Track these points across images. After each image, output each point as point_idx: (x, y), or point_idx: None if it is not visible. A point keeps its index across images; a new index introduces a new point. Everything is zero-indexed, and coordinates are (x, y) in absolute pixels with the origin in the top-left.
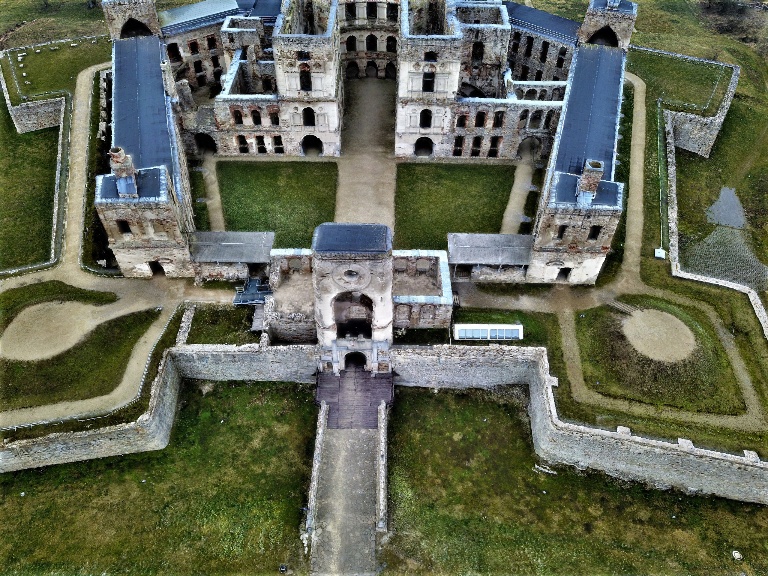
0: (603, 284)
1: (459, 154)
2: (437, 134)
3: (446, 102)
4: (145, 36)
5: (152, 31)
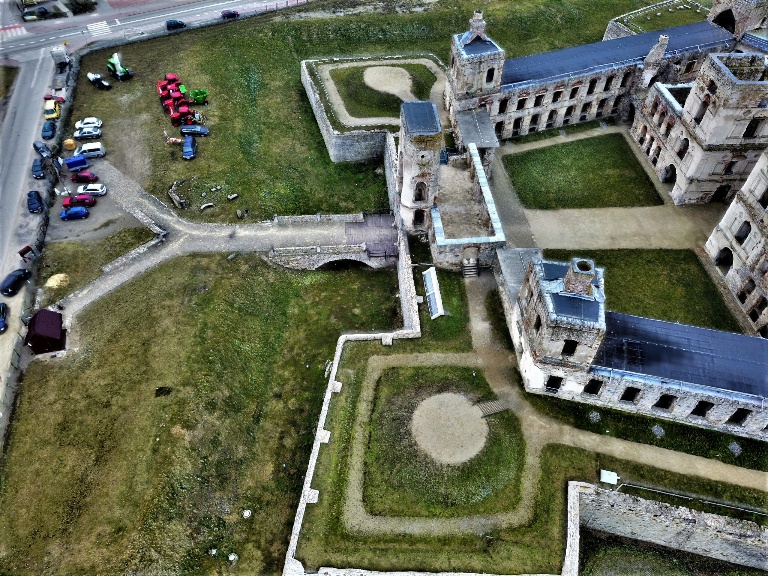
0: (530, 401)
1: (744, 302)
2: (740, 258)
3: (765, 230)
4: (728, 31)
5: (736, 30)
